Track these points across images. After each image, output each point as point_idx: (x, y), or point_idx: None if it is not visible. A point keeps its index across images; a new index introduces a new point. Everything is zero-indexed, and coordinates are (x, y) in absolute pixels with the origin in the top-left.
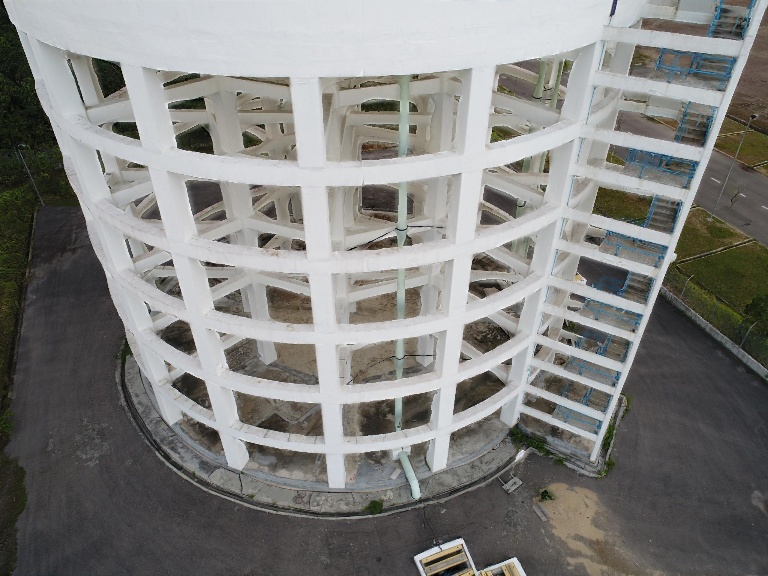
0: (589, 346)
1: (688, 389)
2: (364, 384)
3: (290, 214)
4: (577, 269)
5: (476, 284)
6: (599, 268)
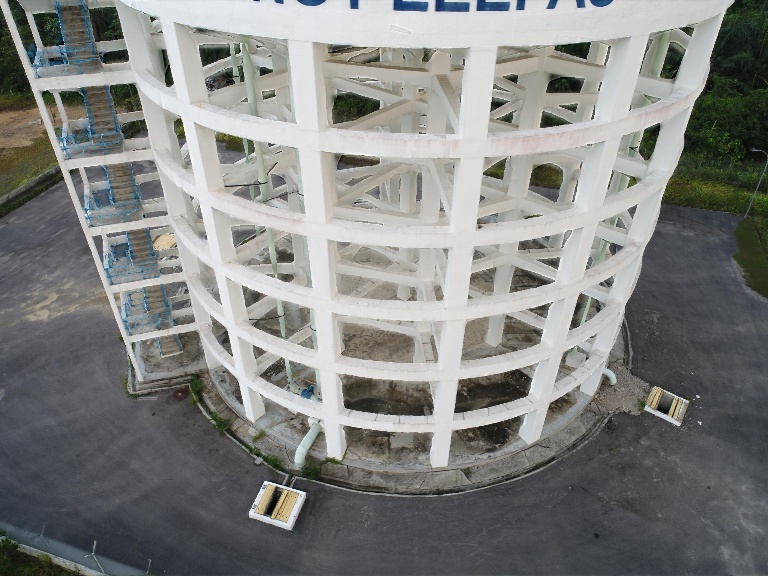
0: (163, 322)
1: (71, 452)
2: (248, 159)
3: (631, 344)
4: (281, 540)
5: (354, 400)
6: (254, 573)
